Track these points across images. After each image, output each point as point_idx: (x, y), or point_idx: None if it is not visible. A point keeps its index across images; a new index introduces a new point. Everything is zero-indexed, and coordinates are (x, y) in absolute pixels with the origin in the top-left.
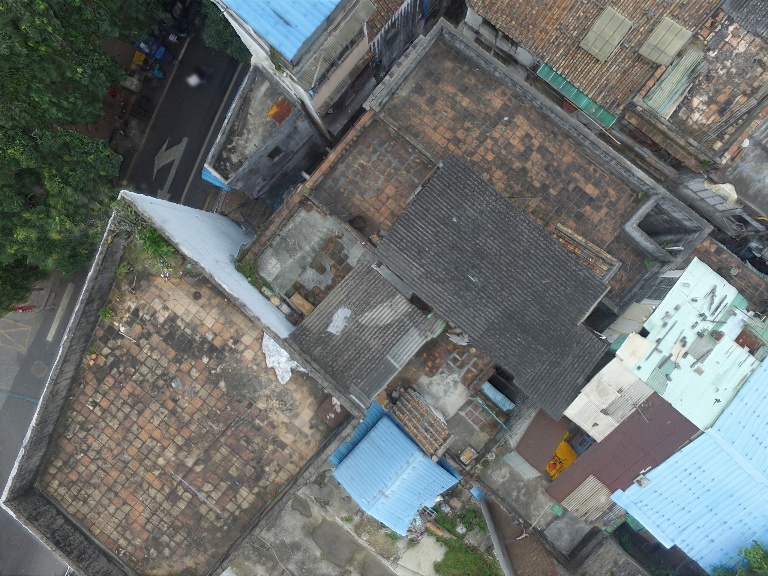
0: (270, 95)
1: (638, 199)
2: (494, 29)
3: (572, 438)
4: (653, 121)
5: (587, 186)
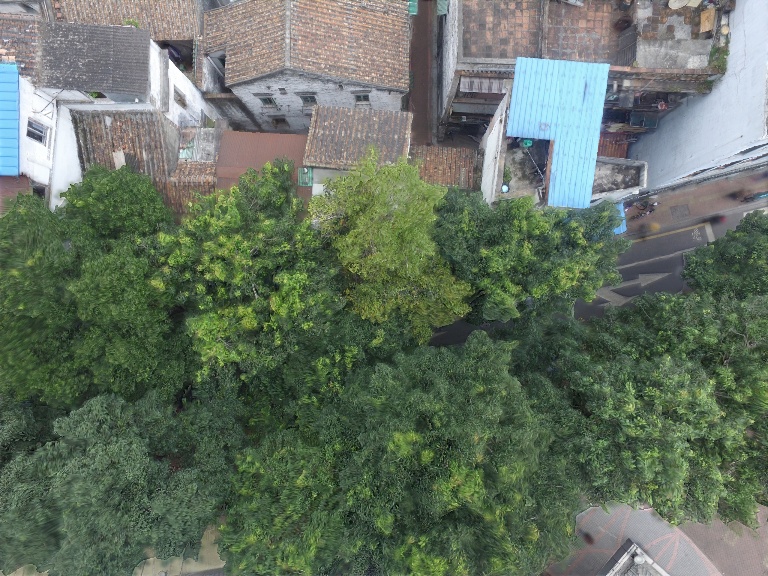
0: None
1: None
2: None
3: None
4: None
5: None
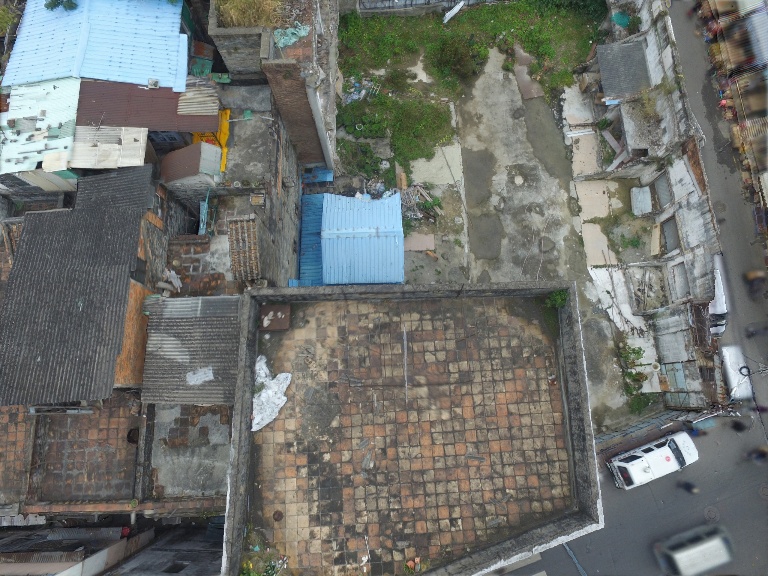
0: None
1: None
2: None
3: None
4: None
5: None
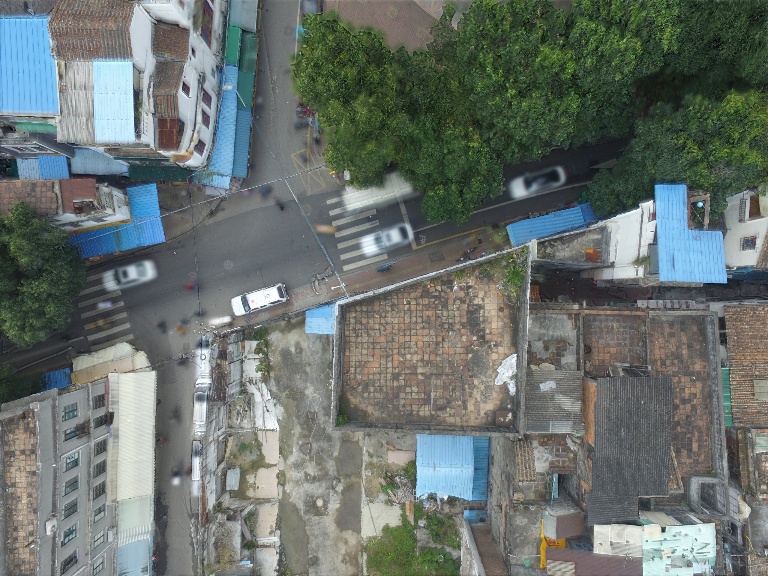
0: (596, 243)
1: (710, 472)
2: (721, 326)
3: (572, 539)
4: (749, 446)
5: (696, 443)
